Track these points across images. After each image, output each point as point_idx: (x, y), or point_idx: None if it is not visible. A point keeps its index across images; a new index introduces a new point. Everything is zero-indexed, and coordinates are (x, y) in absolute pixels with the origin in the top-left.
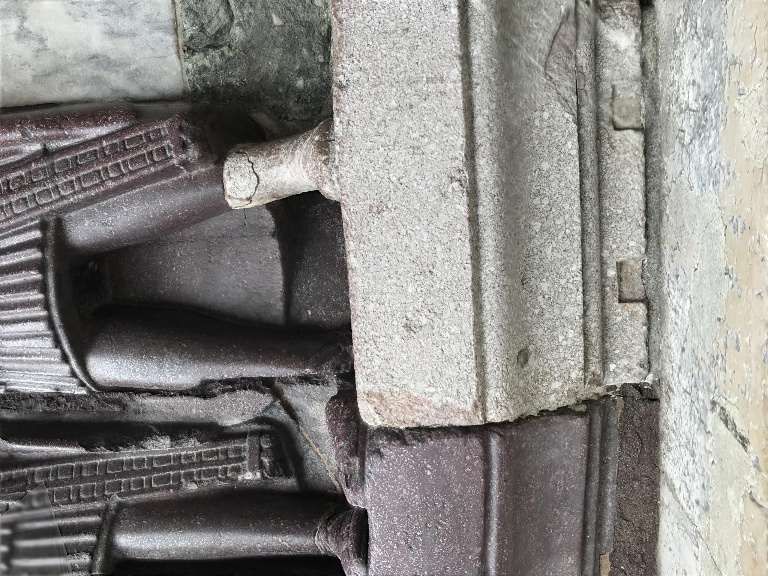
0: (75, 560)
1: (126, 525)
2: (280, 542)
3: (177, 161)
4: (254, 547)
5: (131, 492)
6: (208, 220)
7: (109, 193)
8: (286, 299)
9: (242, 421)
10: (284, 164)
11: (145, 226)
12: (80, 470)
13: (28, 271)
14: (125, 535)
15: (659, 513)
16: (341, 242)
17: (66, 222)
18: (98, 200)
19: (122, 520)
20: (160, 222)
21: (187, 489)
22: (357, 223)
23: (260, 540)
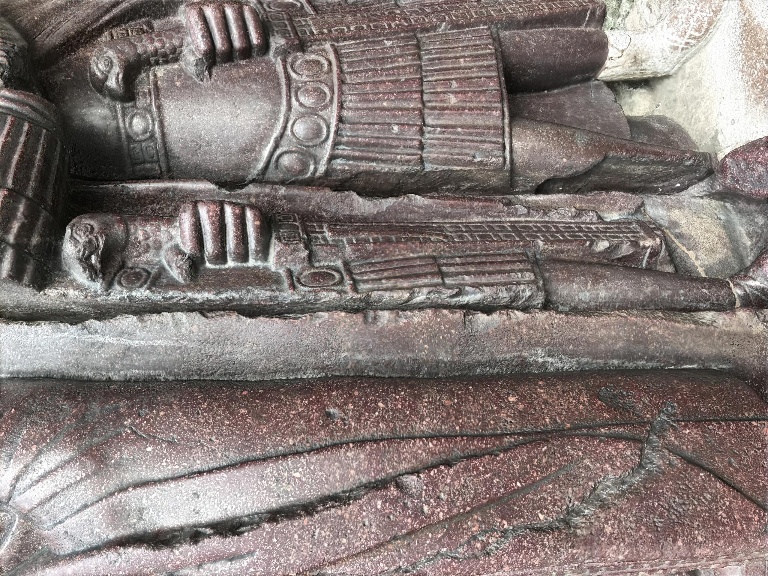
0: (519, 279)
1: (553, 266)
2: (700, 289)
3: (592, 6)
4: (677, 294)
5: (552, 240)
6: (562, 92)
7: (539, 21)
8: (633, 140)
9: (619, 218)
10: (647, 33)
11: (554, 53)
12: (492, 227)
13: (487, 45)
14: (555, 273)
15: None
16: (653, 124)
17: (502, 36)
18: (528, 27)
19: (546, 264)
20: (564, 53)
21: (595, 252)
22: (757, 2)
23: (682, 286)
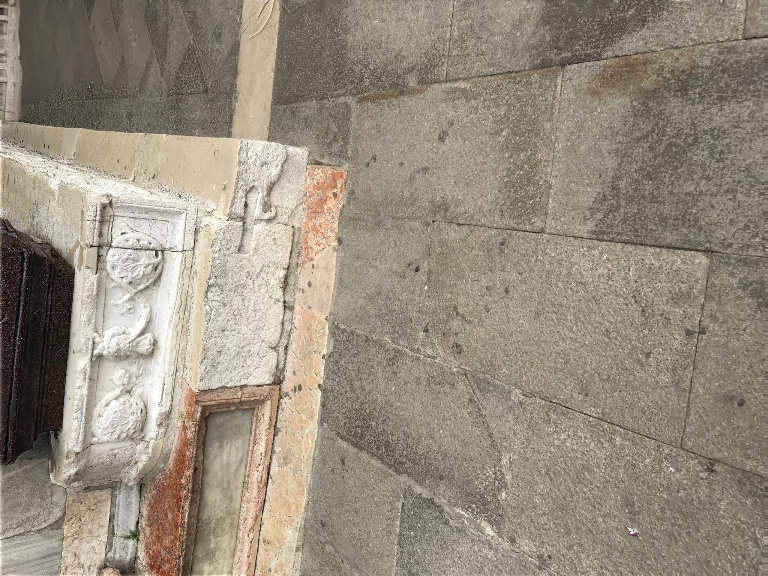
0: None
1: None
2: None
3: None
4: None
5: None
6: None
7: None
8: None
9: None
10: None
11: None
12: None
13: None
14: None
15: (53, 246)
16: None
17: None
18: None
19: None
20: None
21: None
22: None
23: None
